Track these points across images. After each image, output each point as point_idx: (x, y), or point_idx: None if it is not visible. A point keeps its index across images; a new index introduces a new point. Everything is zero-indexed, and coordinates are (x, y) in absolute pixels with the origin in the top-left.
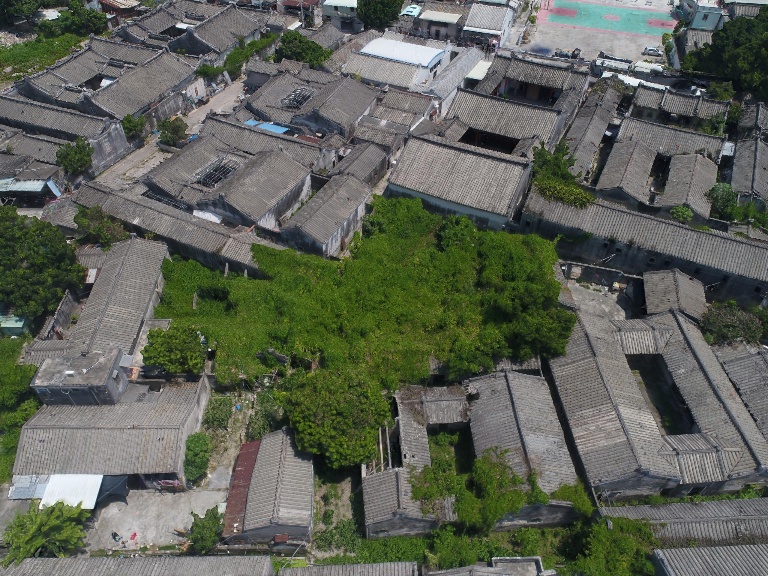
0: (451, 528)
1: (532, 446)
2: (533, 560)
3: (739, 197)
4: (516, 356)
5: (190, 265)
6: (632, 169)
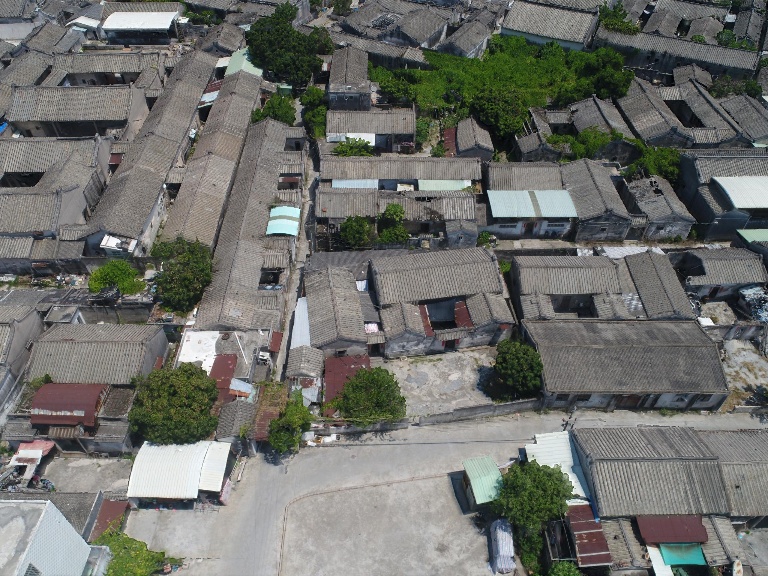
0: (568, 160)
1: (612, 123)
2: (615, 165)
3: (737, 39)
4: (598, 95)
5: (380, 68)
6: (665, 23)
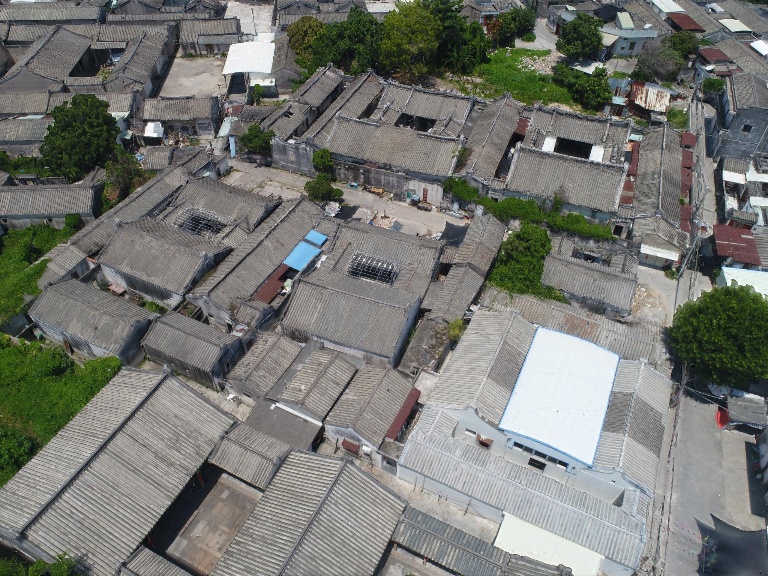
0: None
1: None
2: None
3: None
4: None
5: None
6: None
